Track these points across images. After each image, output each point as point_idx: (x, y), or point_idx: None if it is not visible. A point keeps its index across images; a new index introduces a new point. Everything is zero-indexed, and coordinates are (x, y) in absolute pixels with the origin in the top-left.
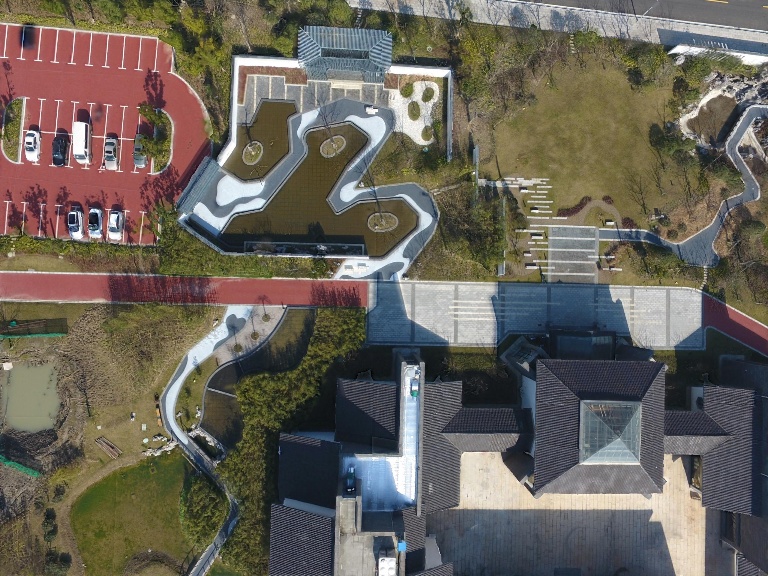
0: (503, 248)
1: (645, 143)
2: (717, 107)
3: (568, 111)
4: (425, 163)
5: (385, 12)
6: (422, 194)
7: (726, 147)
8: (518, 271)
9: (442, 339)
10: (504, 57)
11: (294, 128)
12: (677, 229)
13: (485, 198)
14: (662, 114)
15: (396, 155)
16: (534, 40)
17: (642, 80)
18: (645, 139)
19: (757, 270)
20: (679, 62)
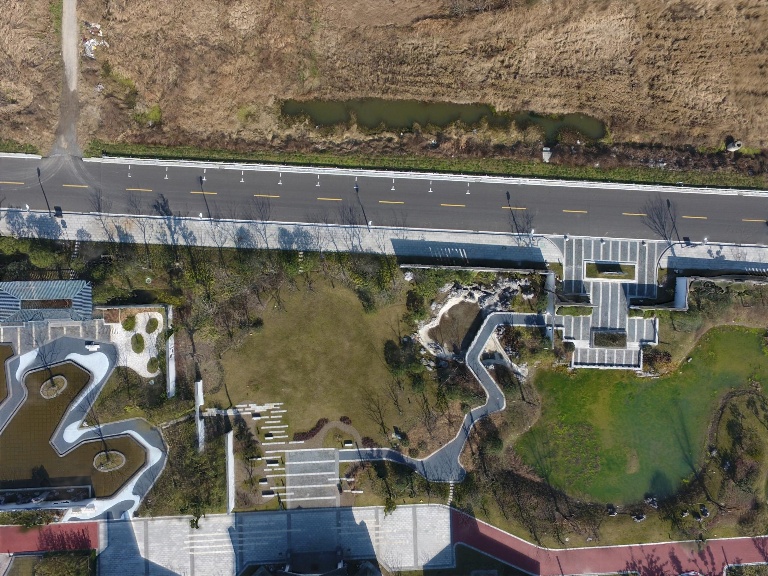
0: (219, 495)
1: (380, 361)
2: (460, 314)
3: (299, 332)
4: (149, 399)
5: (103, 244)
6: (150, 429)
7: (466, 359)
8: (255, 500)
9: (178, 575)
10: (225, 285)
11: (12, 371)
12: (417, 447)
13: (216, 428)
14: (397, 330)
15: (118, 393)
16: (259, 262)
17: (372, 298)
18: (380, 356)
19: (504, 483)
20: (407, 279)
